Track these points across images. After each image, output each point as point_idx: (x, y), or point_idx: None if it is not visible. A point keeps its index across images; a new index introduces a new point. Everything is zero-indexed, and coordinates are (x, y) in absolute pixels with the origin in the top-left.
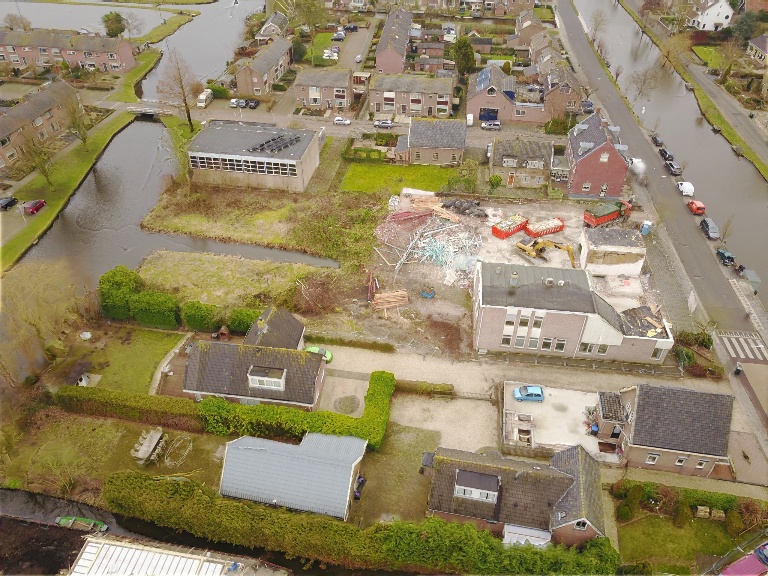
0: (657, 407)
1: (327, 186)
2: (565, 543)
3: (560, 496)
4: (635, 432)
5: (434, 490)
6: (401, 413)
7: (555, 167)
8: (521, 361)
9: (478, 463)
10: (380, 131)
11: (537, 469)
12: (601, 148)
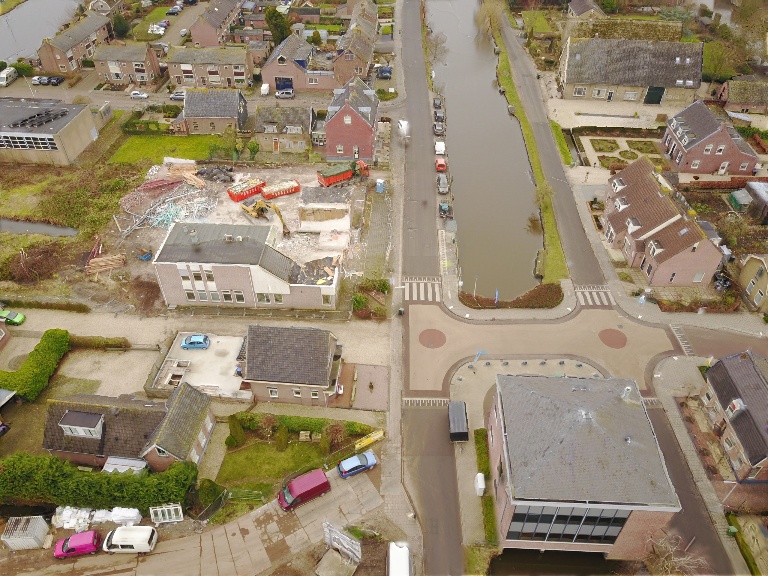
0: (265, 344)
1: (96, 159)
2: (159, 470)
3: (154, 428)
4: (248, 368)
5: (47, 431)
6: (71, 366)
7: (314, 132)
8: (205, 313)
9: (85, 403)
10: (174, 103)
11: (146, 406)
12: (342, 111)
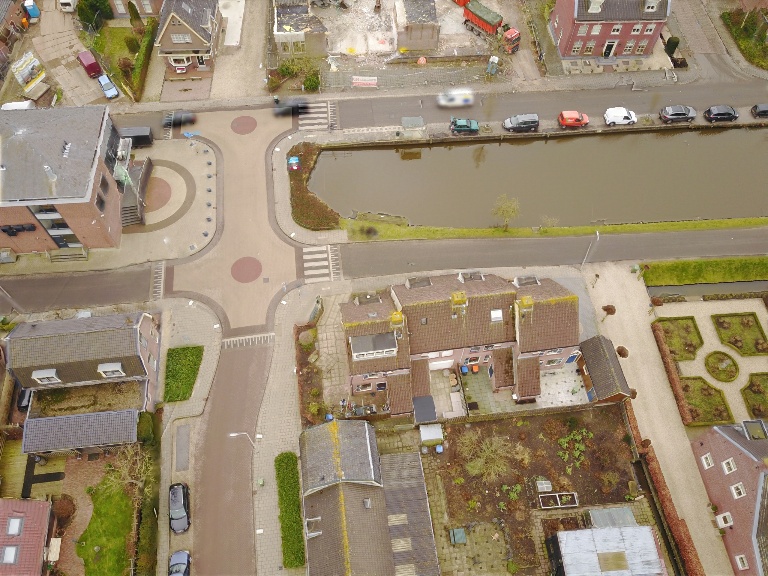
0: None
1: None
2: None
3: None
4: None
5: None
6: None
7: None
8: None
9: None
10: None
11: None
12: None
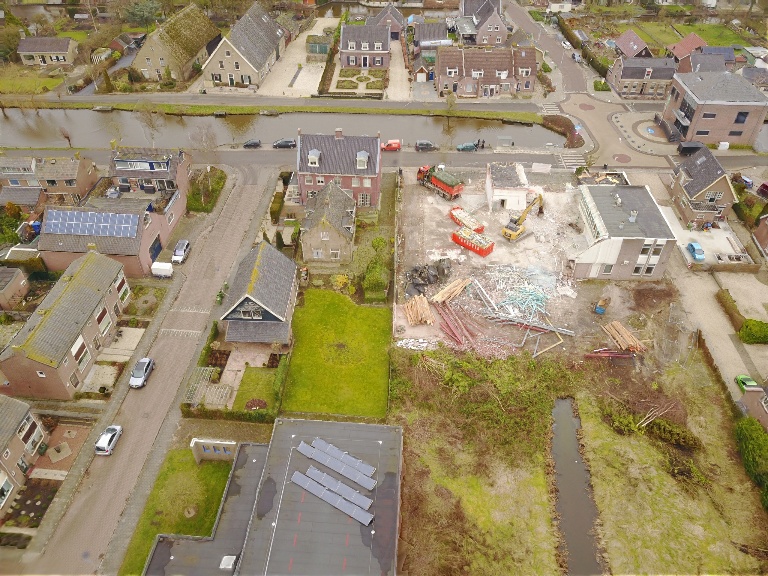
0: None
1: None
2: None
3: None
4: None
5: None
6: None
7: None
8: None
9: None
10: None
11: None
12: None
